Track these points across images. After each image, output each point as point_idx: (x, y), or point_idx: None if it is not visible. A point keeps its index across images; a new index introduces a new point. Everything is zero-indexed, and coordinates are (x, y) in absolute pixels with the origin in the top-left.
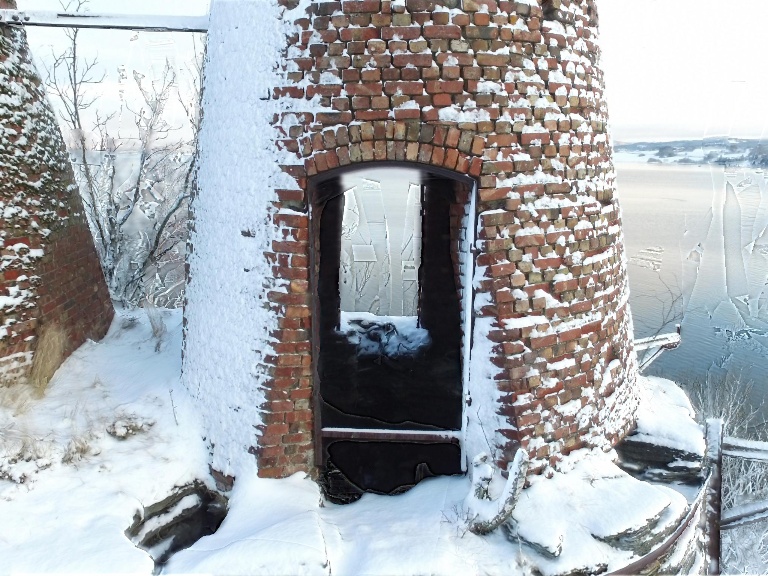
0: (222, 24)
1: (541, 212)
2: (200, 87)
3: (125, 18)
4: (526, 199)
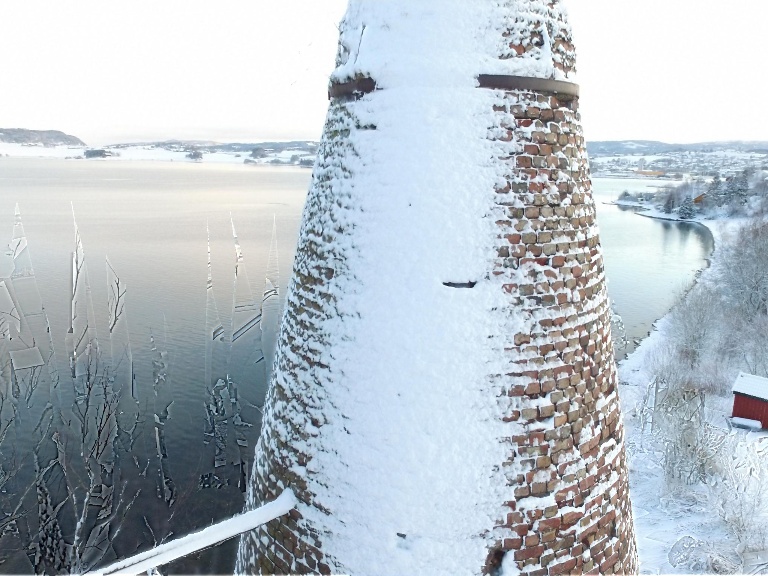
0: (389, 575)
1: None
2: (83, 437)
3: (192, 543)
4: None
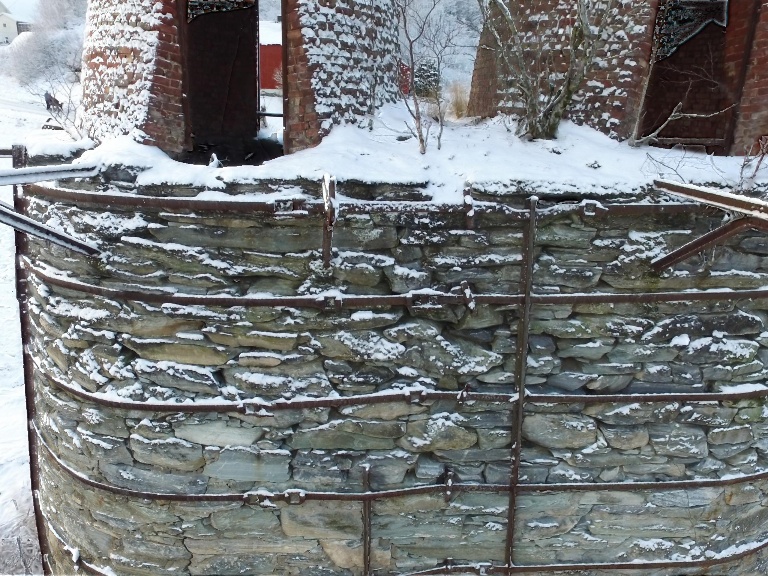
0: None
1: (226, 7)
2: None
3: None
4: (234, 1)
